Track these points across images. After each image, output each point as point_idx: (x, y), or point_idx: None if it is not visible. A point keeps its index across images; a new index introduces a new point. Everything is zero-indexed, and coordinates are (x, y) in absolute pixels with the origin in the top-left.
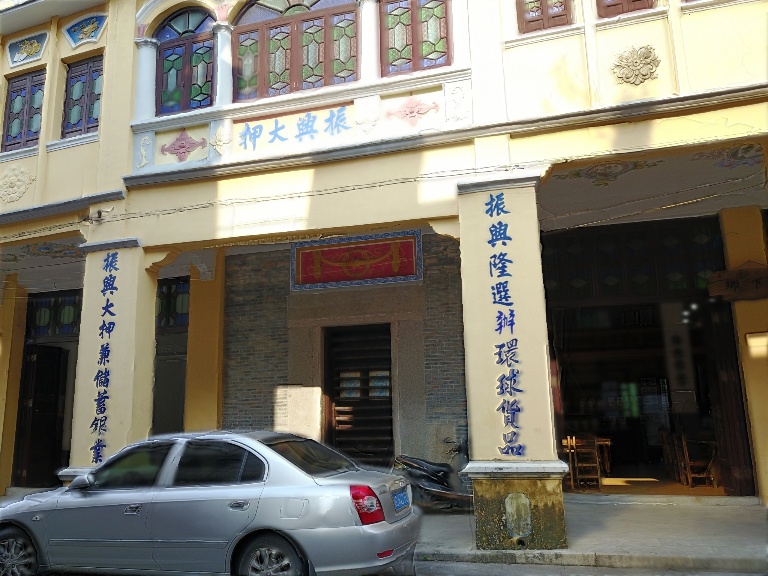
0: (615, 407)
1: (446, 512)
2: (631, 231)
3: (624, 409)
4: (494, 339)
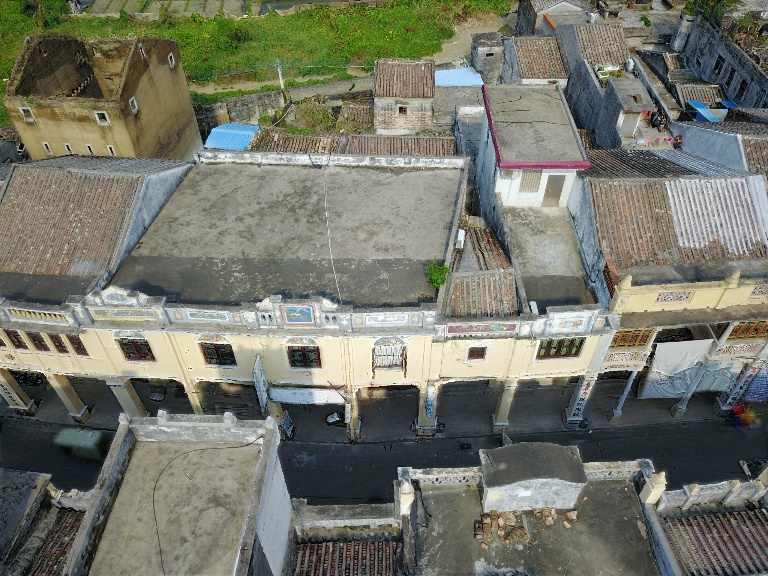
0: None
1: (26, 385)
2: None
3: None
4: (4, 391)
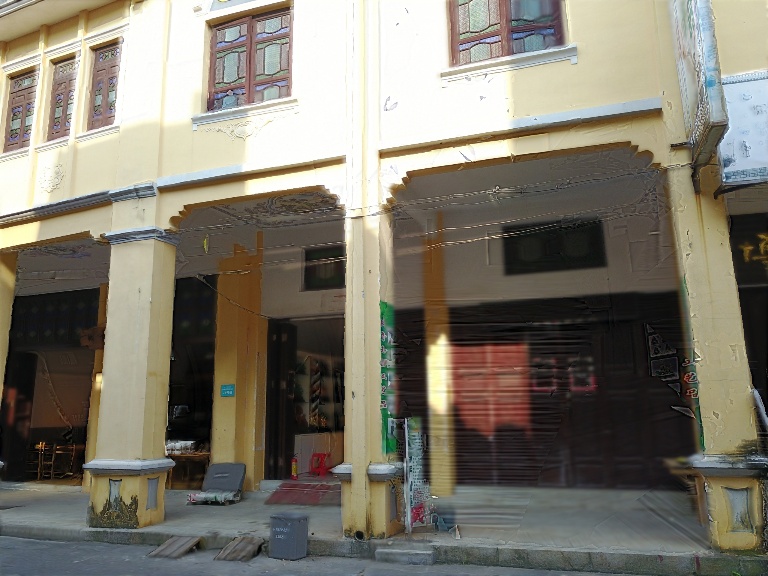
0: (75, 422)
1: None
2: (59, 298)
3: (77, 423)
4: None
